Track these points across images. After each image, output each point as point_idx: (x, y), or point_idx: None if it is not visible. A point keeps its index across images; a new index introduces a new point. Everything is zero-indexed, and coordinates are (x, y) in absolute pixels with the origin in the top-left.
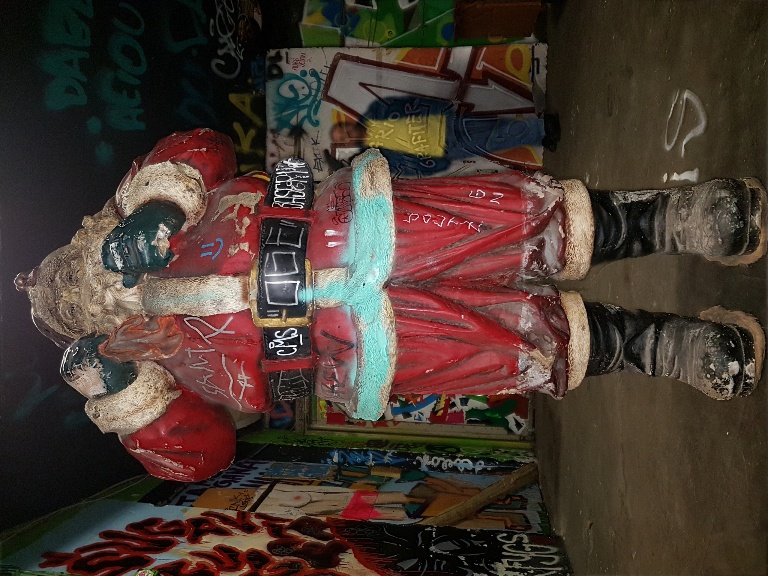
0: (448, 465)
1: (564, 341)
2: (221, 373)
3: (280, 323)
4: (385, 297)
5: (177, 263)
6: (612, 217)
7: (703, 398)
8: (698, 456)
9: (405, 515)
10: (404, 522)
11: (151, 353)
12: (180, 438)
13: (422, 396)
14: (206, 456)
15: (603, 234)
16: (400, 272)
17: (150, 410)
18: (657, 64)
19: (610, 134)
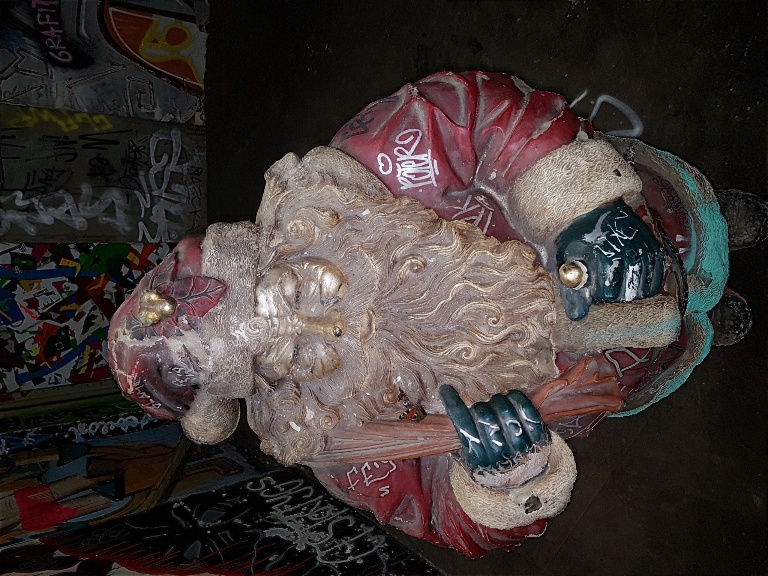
0: (109, 428)
1: None
2: None
3: None
4: None
5: None
6: None
7: None
8: None
9: (107, 500)
10: (115, 508)
11: None
12: None
13: (59, 354)
14: None
15: None
16: None
17: None
18: (540, 56)
19: None
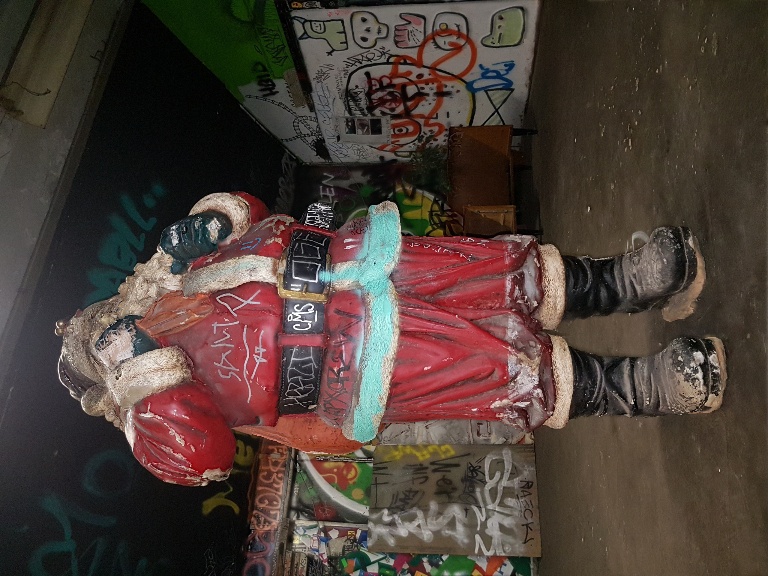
0: None
1: (547, 346)
2: (240, 347)
3: (301, 295)
4: (391, 283)
5: (219, 258)
6: (578, 266)
7: (694, 463)
8: (702, 527)
9: None
10: None
11: (185, 312)
12: (189, 409)
13: None
14: (208, 440)
15: (572, 277)
16: (403, 282)
17: (169, 372)
18: (610, 239)
19: (584, 323)
